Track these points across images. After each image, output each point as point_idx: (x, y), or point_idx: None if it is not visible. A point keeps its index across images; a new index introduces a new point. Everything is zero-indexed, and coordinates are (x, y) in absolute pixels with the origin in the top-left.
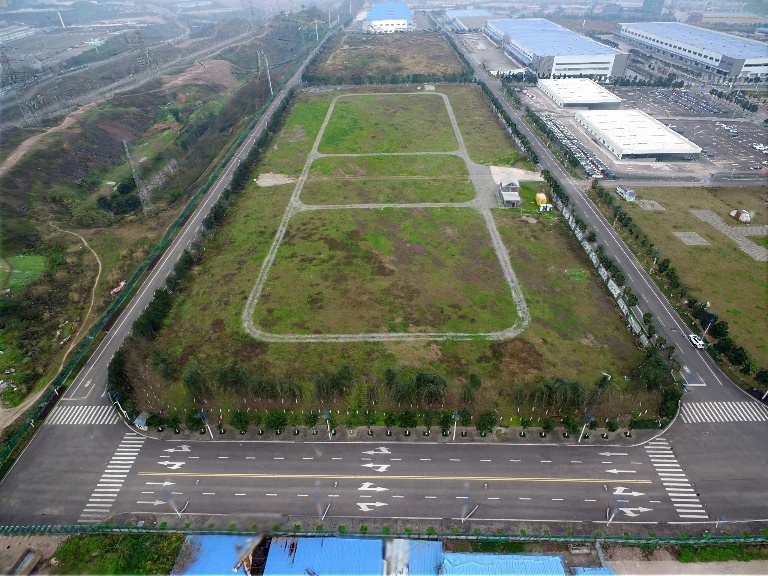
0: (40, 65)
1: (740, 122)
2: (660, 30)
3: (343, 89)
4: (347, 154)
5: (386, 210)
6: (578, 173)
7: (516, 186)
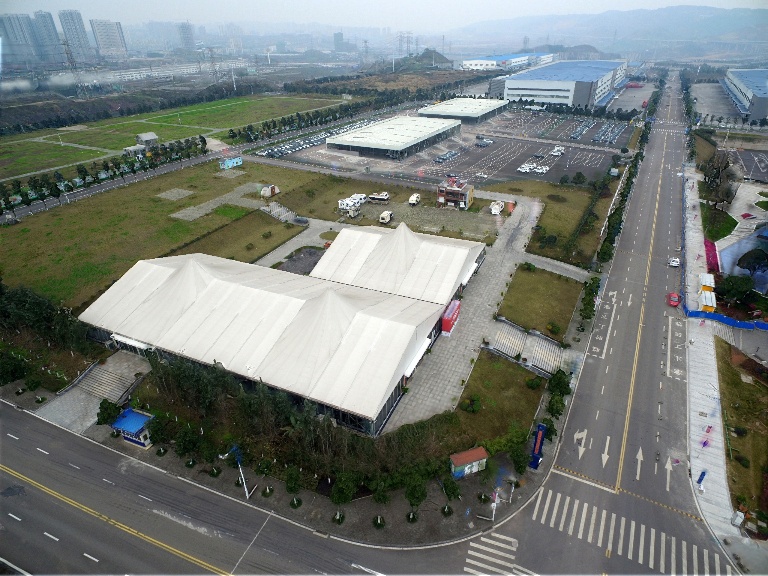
0: (103, 60)
1: (601, 151)
2: (764, 75)
3: (288, 94)
4: (155, 122)
5: (62, 146)
6: (256, 150)
7: (141, 139)
